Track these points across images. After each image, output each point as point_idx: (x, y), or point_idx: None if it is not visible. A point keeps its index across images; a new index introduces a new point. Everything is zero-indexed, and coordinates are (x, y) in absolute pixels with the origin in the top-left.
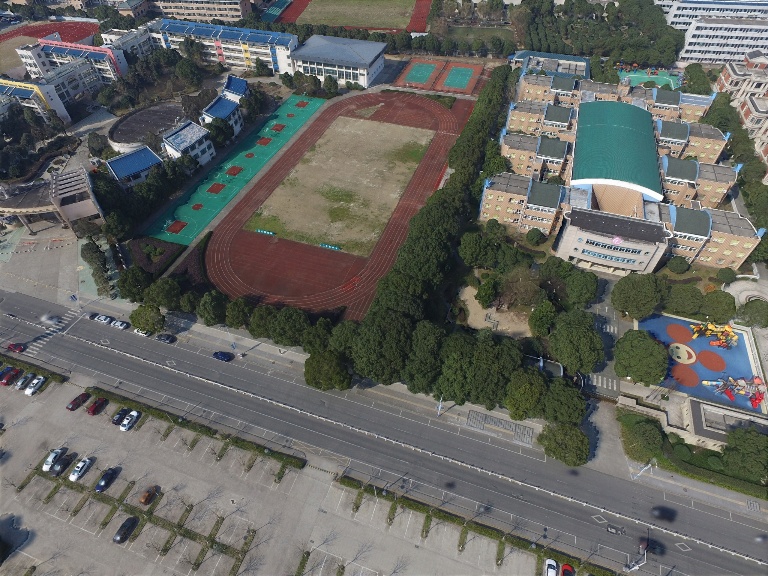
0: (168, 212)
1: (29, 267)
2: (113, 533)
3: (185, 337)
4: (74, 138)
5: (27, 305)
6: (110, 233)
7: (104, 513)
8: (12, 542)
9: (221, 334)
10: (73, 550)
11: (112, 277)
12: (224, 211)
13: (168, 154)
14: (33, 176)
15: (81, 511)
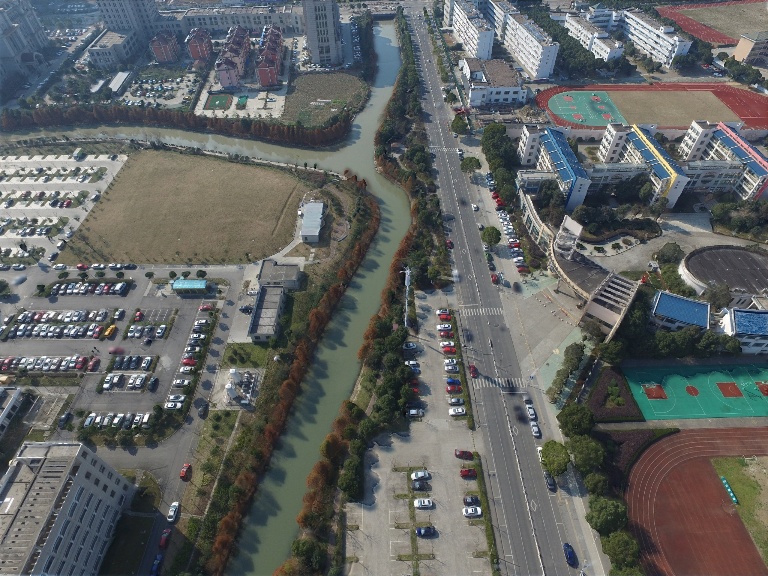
0: (662, 370)
1: (531, 316)
2: (397, 571)
3: (563, 498)
4: (658, 229)
5: (505, 345)
6: (602, 352)
7: (406, 551)
8: (365, 497)
9: (588, 534)
10: (377, 548)
11: (568, 383)
12: (712, 421)
13: (720, 320)
14: (600, 241)
15: (400, 530)
